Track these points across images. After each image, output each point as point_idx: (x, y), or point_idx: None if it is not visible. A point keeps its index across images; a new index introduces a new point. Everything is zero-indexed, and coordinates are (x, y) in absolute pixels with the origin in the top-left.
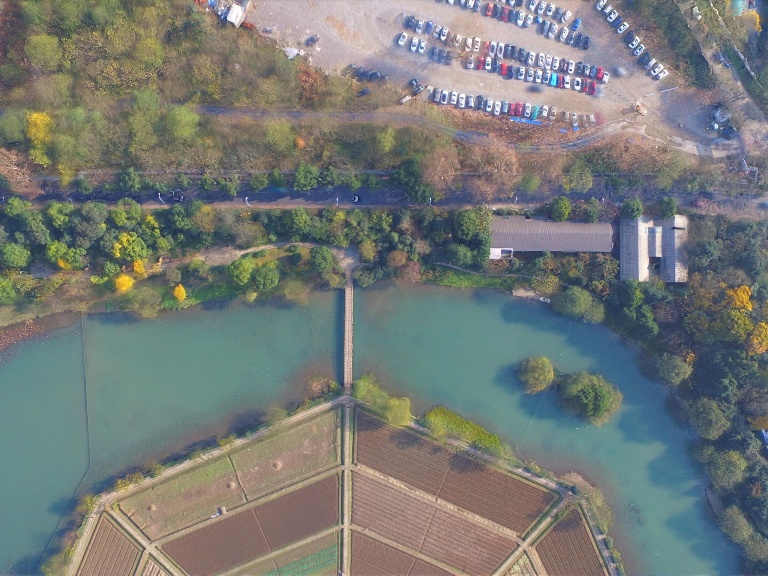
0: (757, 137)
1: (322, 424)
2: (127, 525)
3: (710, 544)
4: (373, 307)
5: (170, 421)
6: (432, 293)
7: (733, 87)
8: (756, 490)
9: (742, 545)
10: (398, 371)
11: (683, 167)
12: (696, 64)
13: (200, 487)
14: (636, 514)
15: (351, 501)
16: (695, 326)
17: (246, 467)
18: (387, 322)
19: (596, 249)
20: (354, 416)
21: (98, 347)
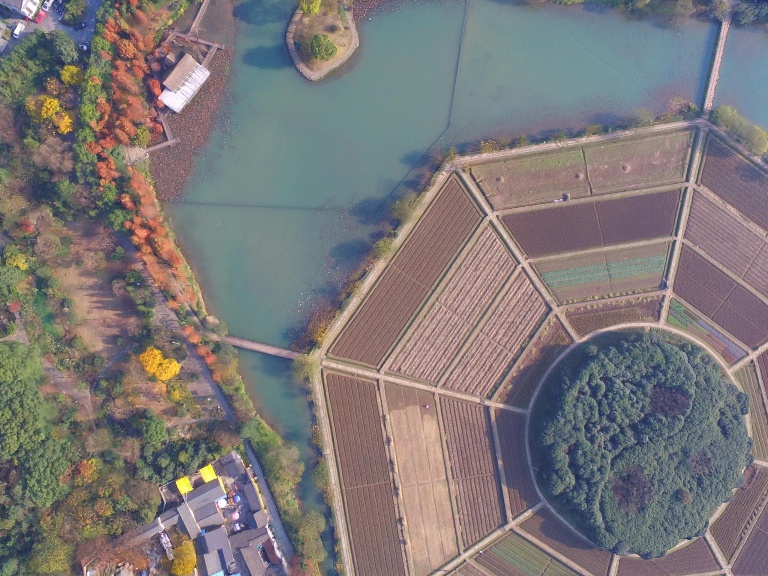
0: None
1: (675, 140)
2: (474, 189)
3: None
4: (742, 46)
5: (532, 105)
6: None
7: None
8: None
9: None
10: (754, 110)
11: None
12: None
13: (550, 171)
14: None
15: (688, 217)
16: None
17: (596, 163)
18: (753, 63)
19: None
20: (706, 140)
21: (478, 20)
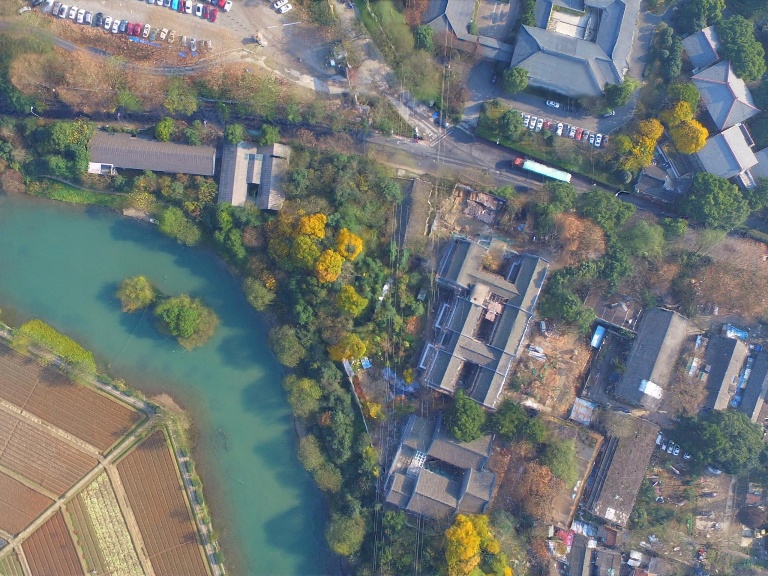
0: (375, 78)
1: None
2: None
3: (294, 474)
4: None
5: None
6: (42, 206)
7: (356, 27)
8: (325, 418)
9: (312, 474)
10: None
11: (298, 100)
12: (319, 1)
13: None
14: (223, 439)
15: None
16: (274, 251)
17: None
18: None
19: (197, 171)
20: None
21: None
